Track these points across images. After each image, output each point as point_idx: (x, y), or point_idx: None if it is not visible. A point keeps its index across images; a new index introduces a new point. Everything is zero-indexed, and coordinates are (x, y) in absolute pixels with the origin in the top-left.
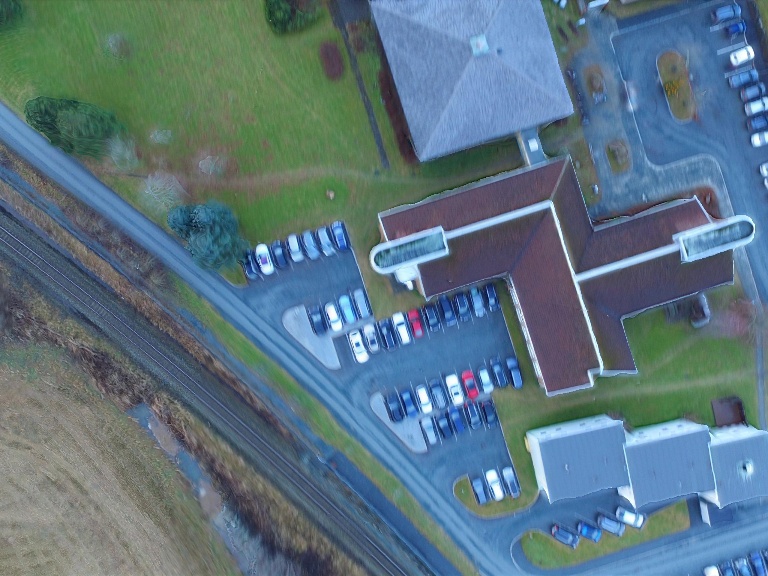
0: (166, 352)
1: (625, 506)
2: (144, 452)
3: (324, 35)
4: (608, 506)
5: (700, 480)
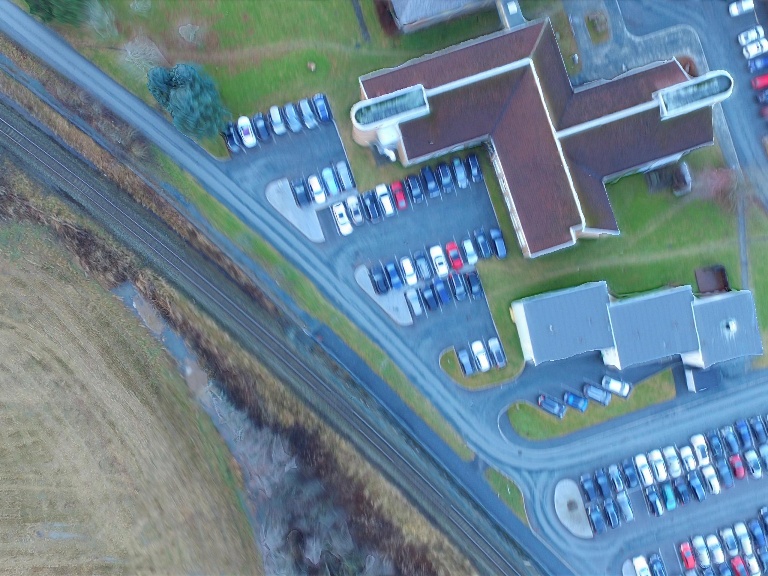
0: (150, 228)
1: (611, 375)
2: (129, 330)
3: None
4: (594, 376)
5: (684, 340)
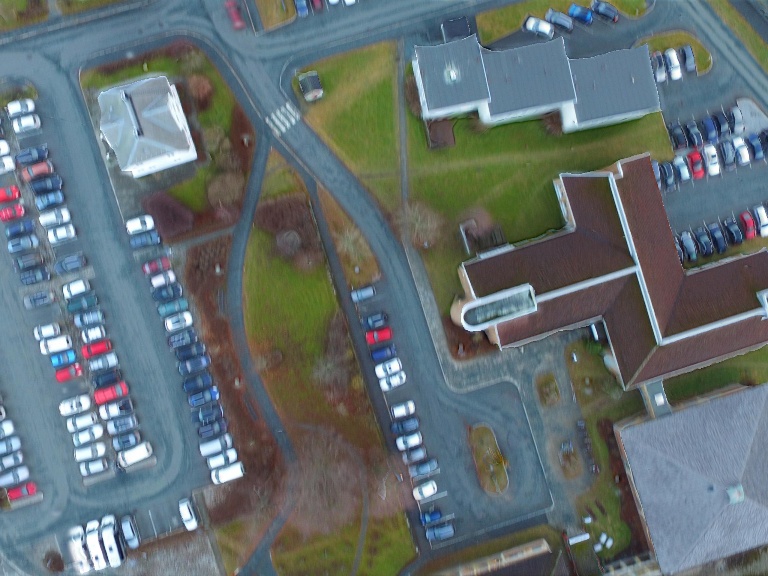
0: None
1: (546, 39)
2: None
3: None
4: None
5: (499, 64)
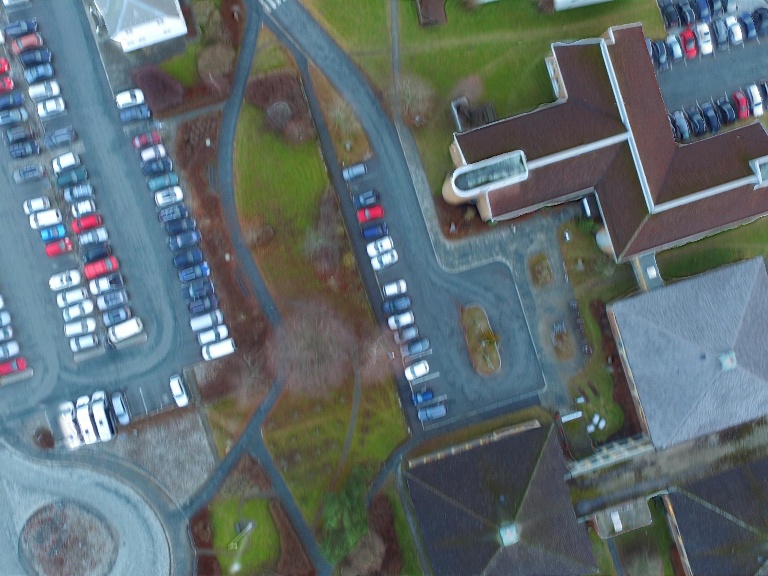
0: None
1: None
2: None
3: None
4: None
5: None
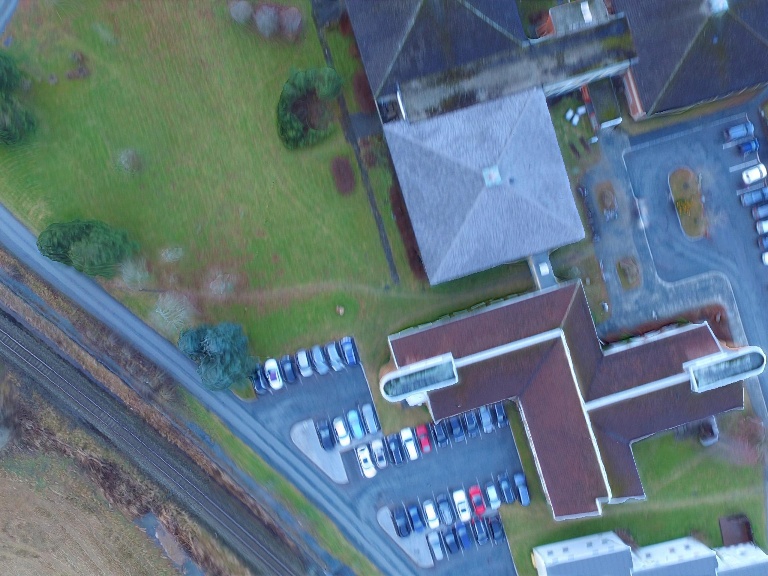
0: (174, 463)
1: None
2: (151, 562)
3: (336, 150)
4: None
5: None
